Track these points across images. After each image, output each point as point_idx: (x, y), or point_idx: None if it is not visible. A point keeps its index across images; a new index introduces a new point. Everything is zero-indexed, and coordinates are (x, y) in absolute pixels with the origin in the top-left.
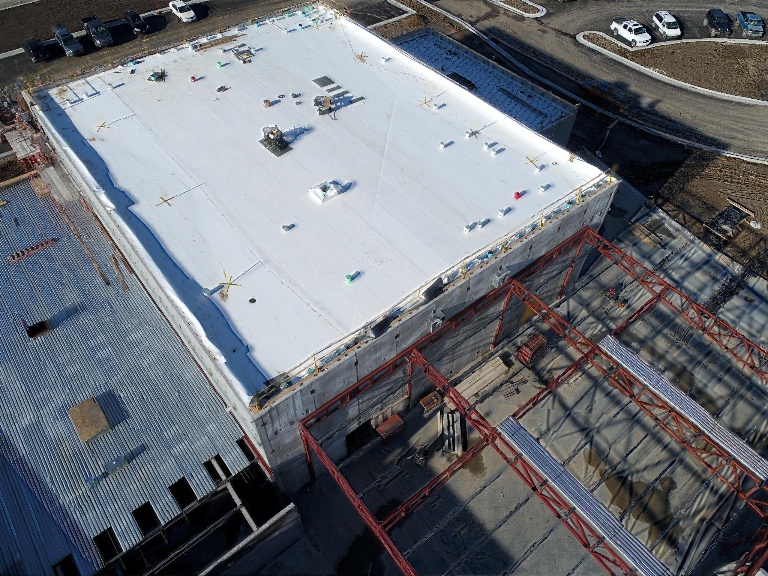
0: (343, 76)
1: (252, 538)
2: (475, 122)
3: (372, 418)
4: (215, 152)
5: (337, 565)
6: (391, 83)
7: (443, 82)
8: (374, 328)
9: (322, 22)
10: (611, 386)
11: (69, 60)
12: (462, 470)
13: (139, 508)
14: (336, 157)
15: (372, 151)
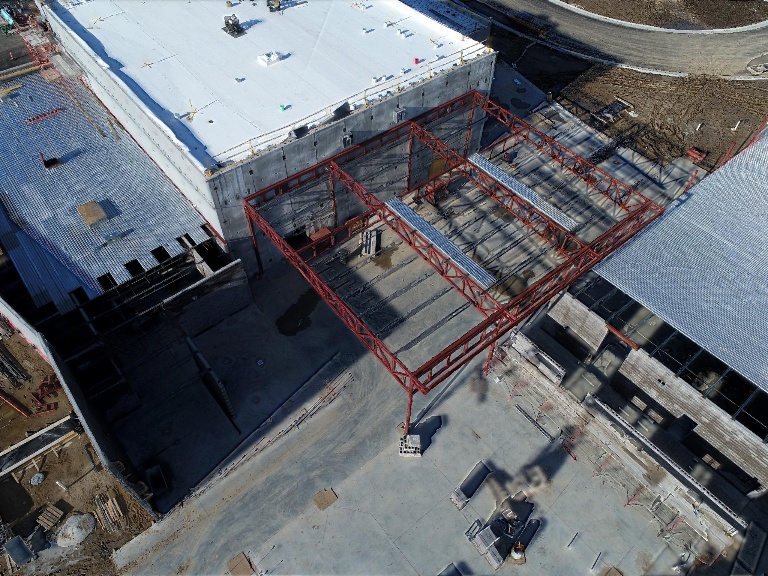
0: None
1: (210, 277)
2: (394, 17)
3: (305, 225)
4: (187, 35)
5: (276, 320)
6: None
7: None
8: (296, 130)
9: None
10: (496, 217)
11: None
12: (375, 266)
13: (129, 263)
14: (281, 38)
15: (309, 35)
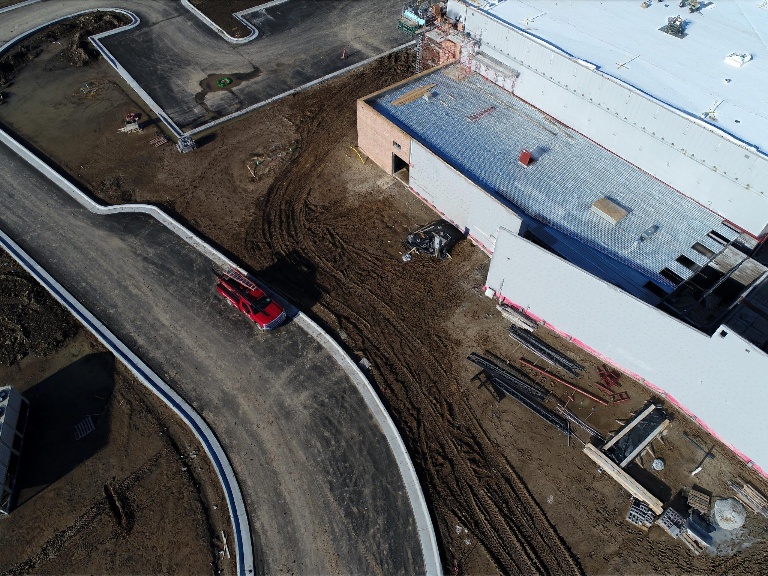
0: None
1: None
2: None
3: None
4: (631, 36)
5: None
6: None
7: None
8: None
9: None
10: None
11: None
12: None
13: None
14: (726, 39)
15: (750, 36)
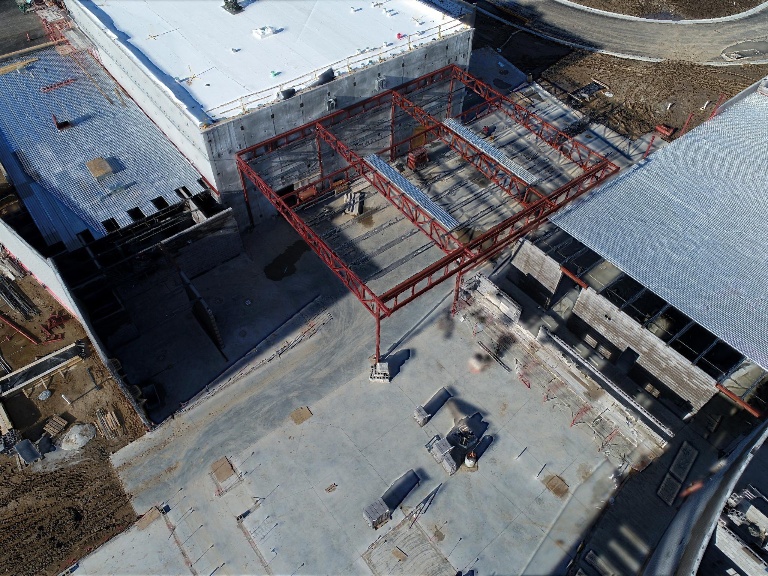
0: None
1: (203, 223)
2: None
3: (294, 184)
4: (189, 12)
5: (264, 267)
6: None
7: None
8: (283, 92)
9: None
10: (472, 182)
11: None
12: None
13: (131, 210)
14: (275, 15)
15: (302, 13)
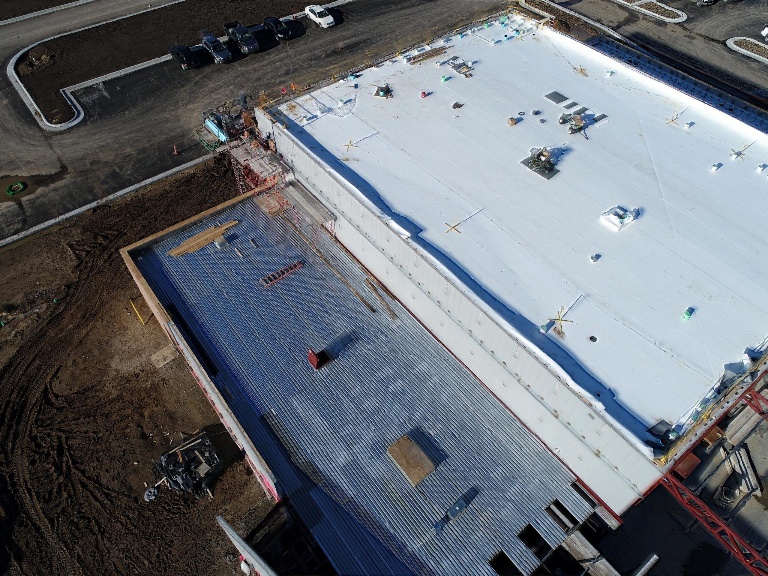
0: (573, 91)
1: None
2: (733, 142)
3: None
4: (480, 174)
5: None
6: (627, 99)
7: (684, 98)
8: None
9: (524, 33)
10: None
11: (218, 67)
12: (766, 512)
13: None
14: (609, 180)
15: (643, 174)
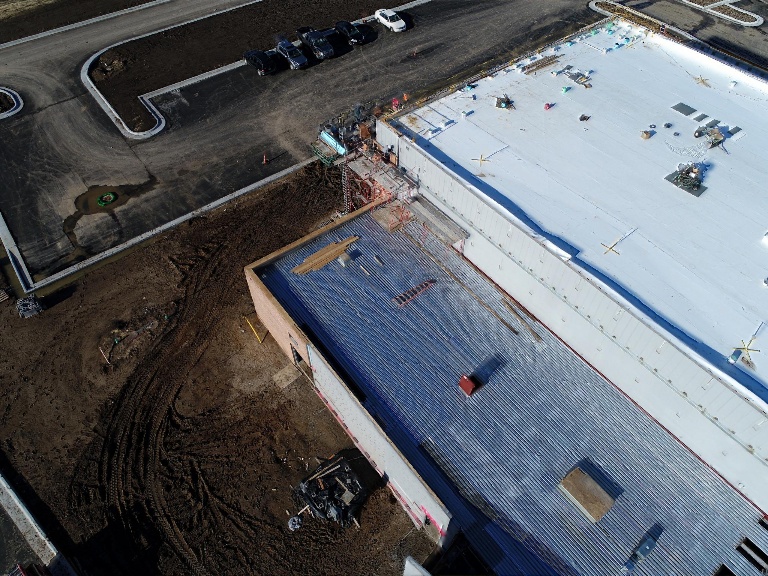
0: (700, 102)
1: None
2: None
3: None
4: (625, 191)
5: None
6: (757, 111)
7: None
8: None
9: (633, 40)
10: None
11: (295, 73)
12: None
13: None
14: (762, 198)
15: None
